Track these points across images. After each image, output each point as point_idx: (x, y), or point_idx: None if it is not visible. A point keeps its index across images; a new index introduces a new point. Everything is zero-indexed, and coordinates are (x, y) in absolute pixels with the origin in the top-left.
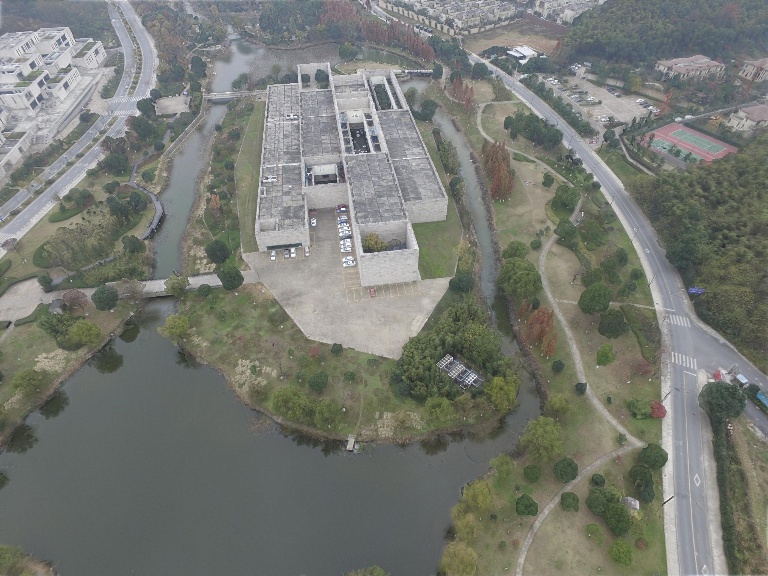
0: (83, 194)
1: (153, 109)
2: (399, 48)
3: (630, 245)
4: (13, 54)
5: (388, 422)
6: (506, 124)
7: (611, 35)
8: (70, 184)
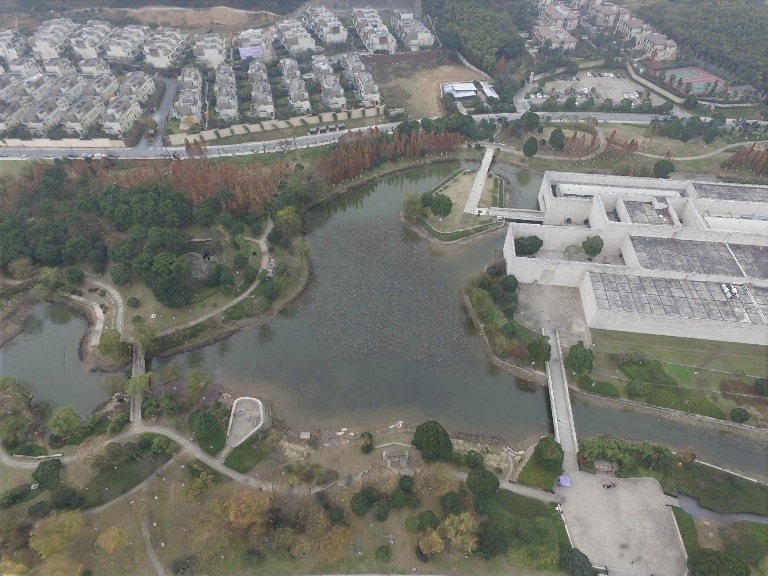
0: None
1: None
2: (385, 163)
3: None
4: None
5: None
6: None
7: (503, 37)
8: None
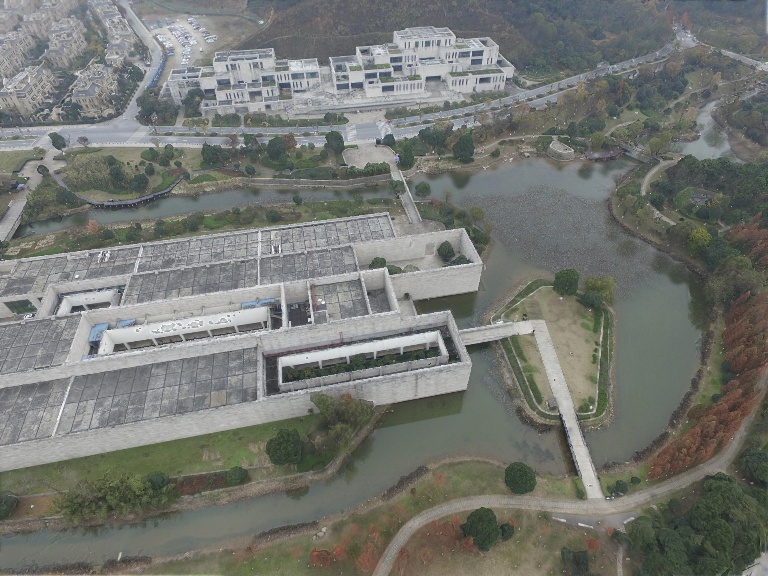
0: (164, 152)
1: (336, 146)
2: None
3: None
4: (400, 44)
5: None
6: None
7: None
8: None
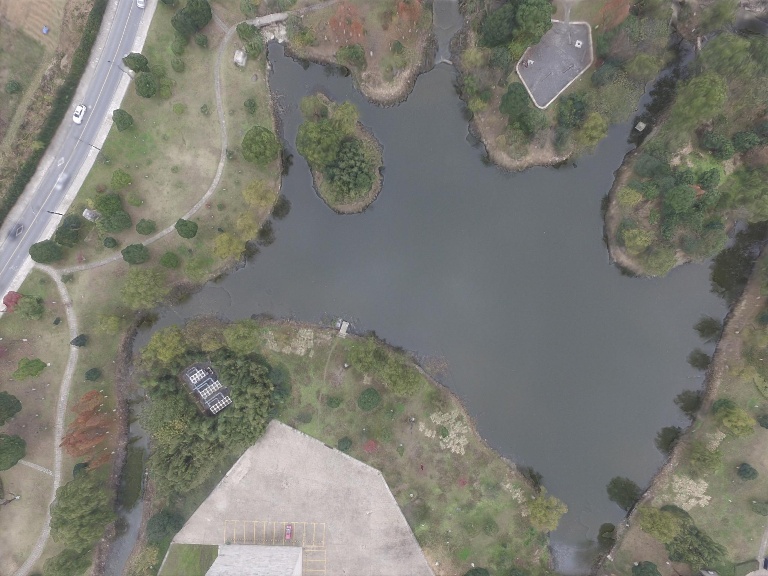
0: None
1: None
2: None
3: None
4: None
5: (301, 344)
6: None
7: None
8: None
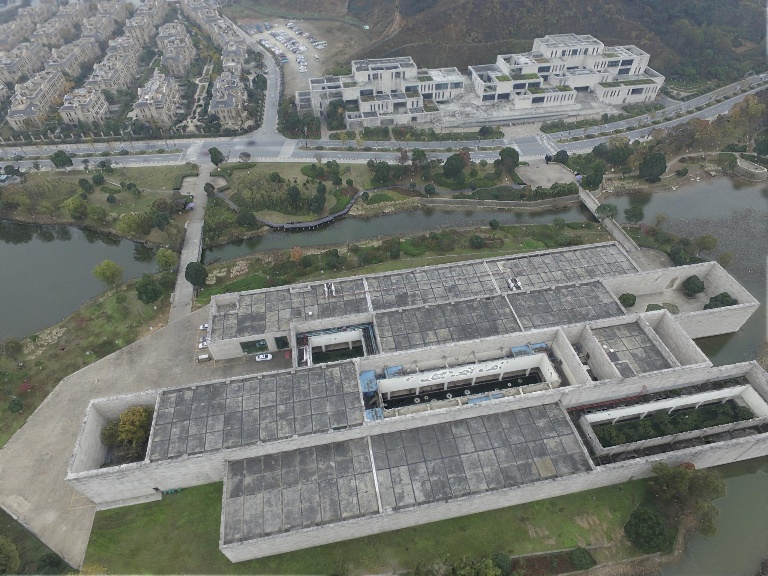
0: (331, 169)
1: (512, 163)
2: None
3: None
4: (546, 53)
5: None
6: None
7: None
8: (365, 160)
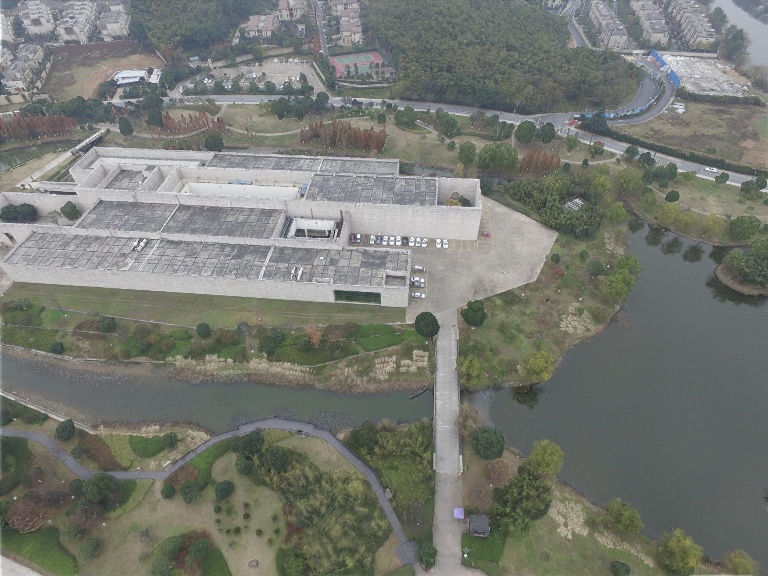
0: (178, 545)
1: None
2: None
3: (457, 116)
4: None
5: None
6: (281, 114)
7: (189, 26)
8: None
